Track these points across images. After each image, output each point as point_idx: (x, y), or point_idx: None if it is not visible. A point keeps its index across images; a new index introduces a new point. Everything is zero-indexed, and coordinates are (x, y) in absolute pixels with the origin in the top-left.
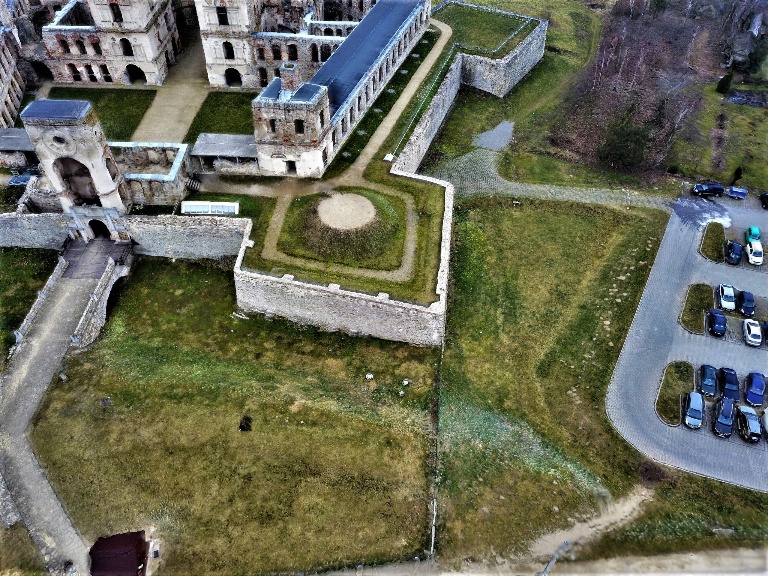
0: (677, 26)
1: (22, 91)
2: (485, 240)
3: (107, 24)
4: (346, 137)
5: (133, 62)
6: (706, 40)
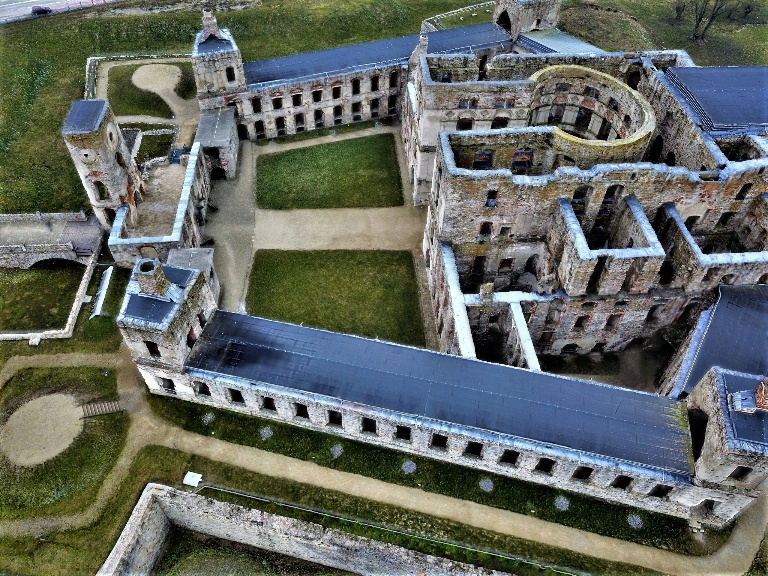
0: None
1: (374, 117)
2: None
3: None
4: (245, 411)
5: None
6: None
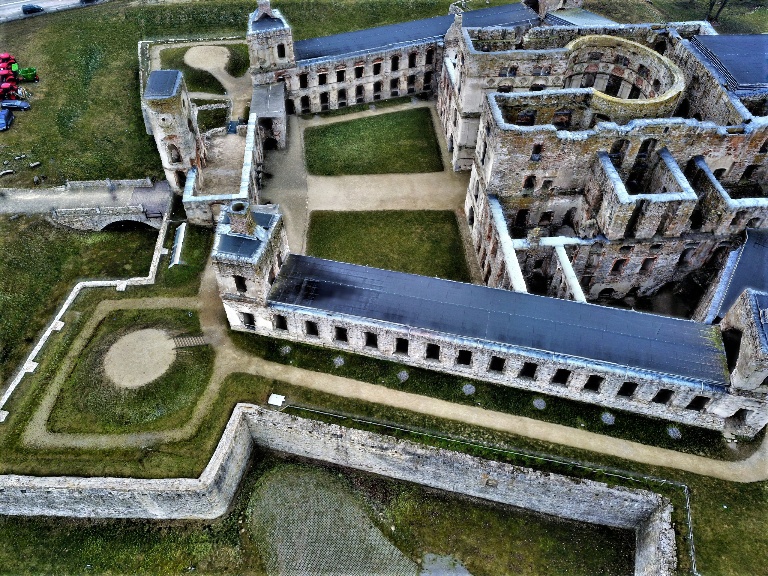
0: None
1: (410, 93)
2: (165, 572)
3: None
4: (318, 343)
5: None
6: None
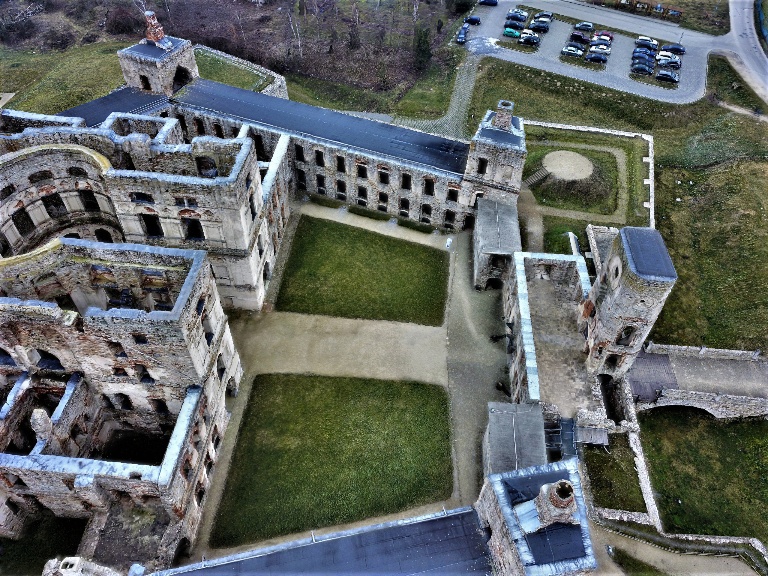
0: (172, 8)
1: None
2: None
3: (205, 362)
4: None
5: (227, 379)
6: (206, 2)
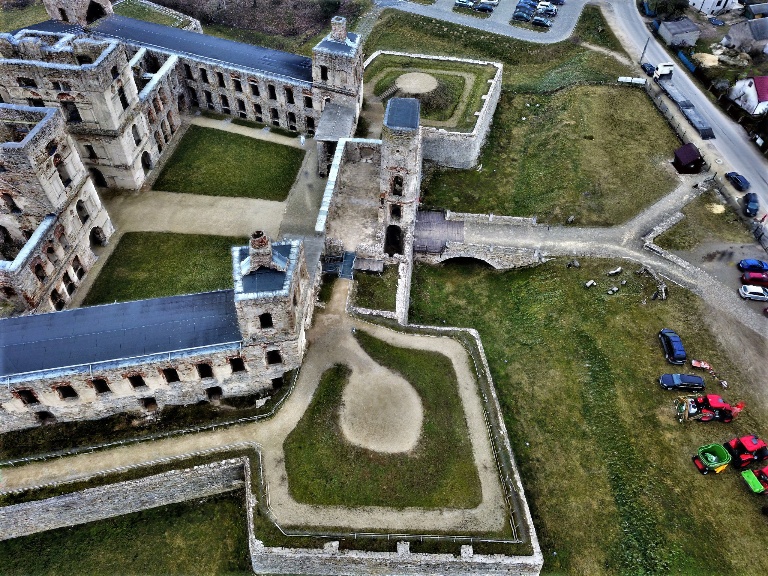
0: None
1: None
2: None
3: (61, 198)
4: None
5: (91, 225)
6: None
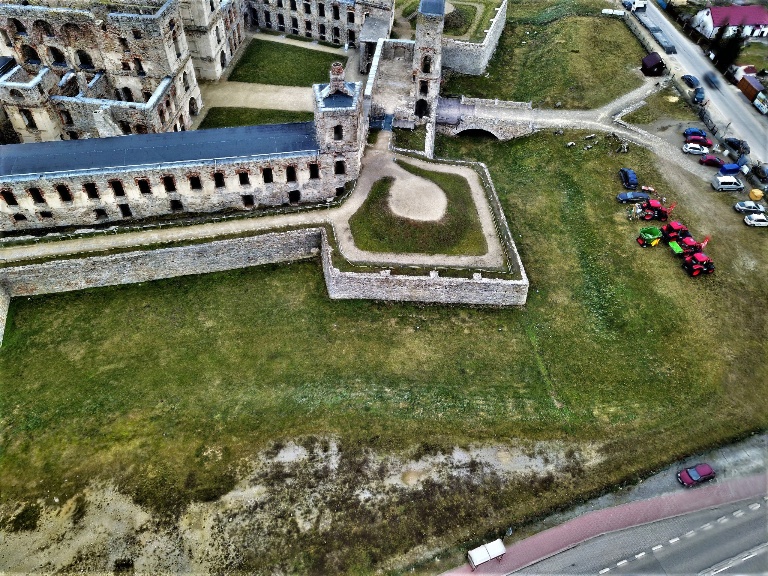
0: None
1: None
2: None
3: (175, 65)
4: None
5: (190, 95)
6: None
